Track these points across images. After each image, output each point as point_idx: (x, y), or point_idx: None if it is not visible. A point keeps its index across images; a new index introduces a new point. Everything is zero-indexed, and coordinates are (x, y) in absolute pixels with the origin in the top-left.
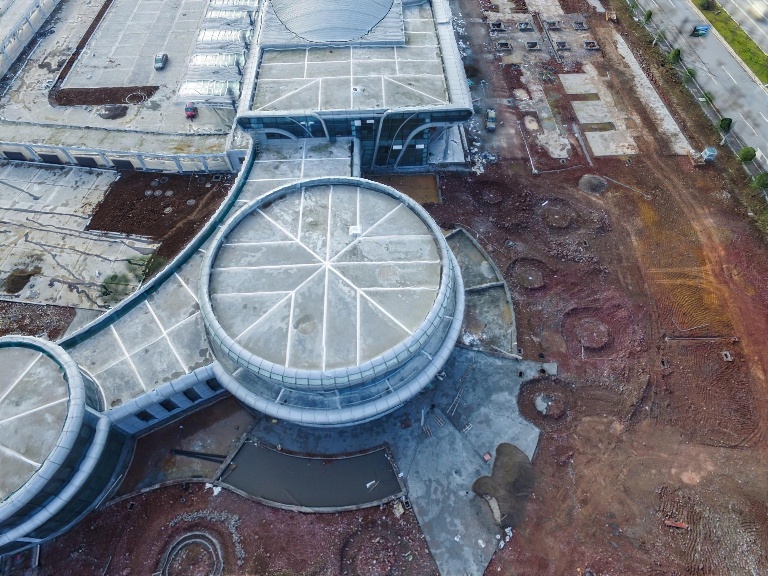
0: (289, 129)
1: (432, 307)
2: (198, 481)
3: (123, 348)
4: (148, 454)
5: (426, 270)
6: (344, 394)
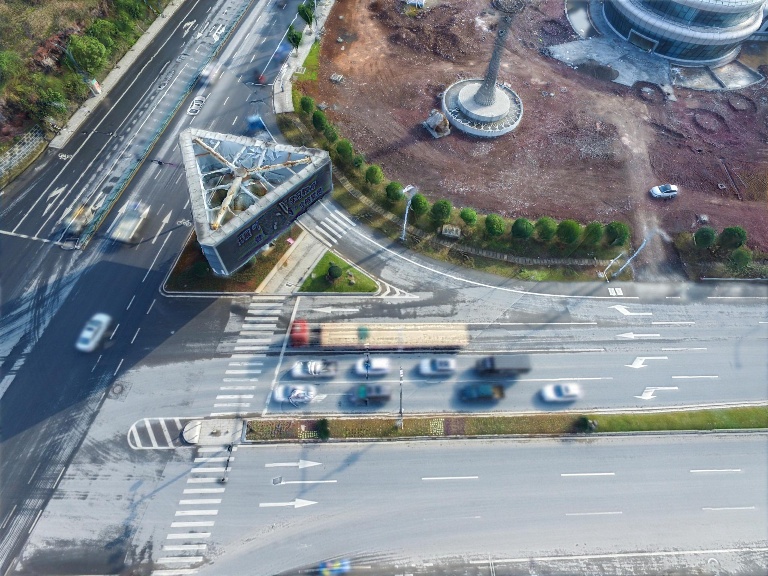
0: None
1: None
2: None
3: None
4: None
5: None
6: None
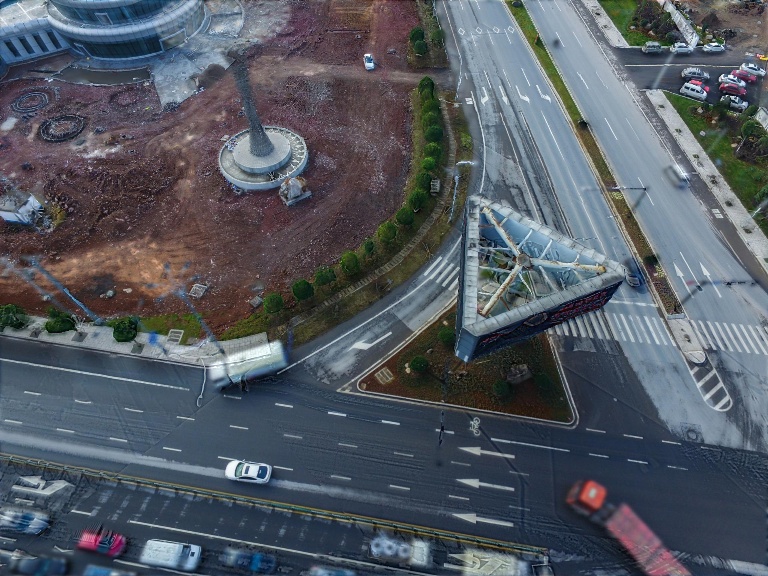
0: None
1: None
2: (40, 77)
3: (1, 18)
4: (15, 72)
5: None
6: (116, 25)
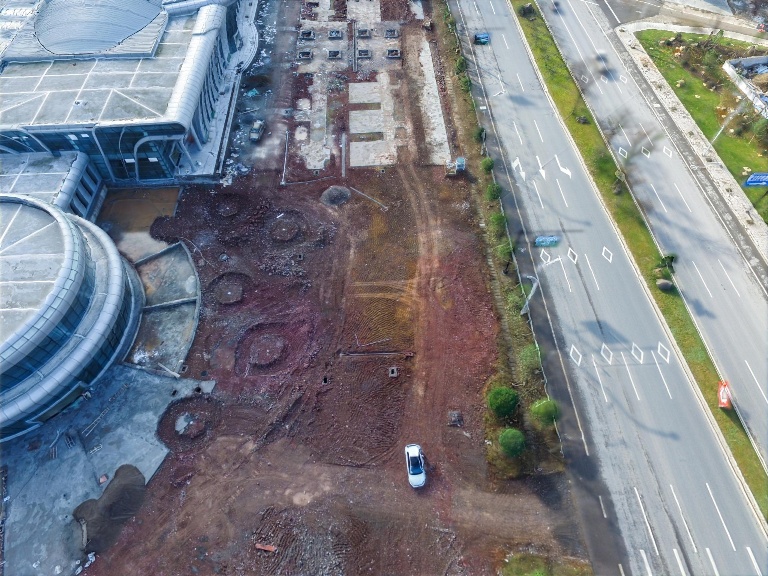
0: (5, 144)
1: (19, 329)
2: None
3: None
4: None
5: (44, 290)
6: None
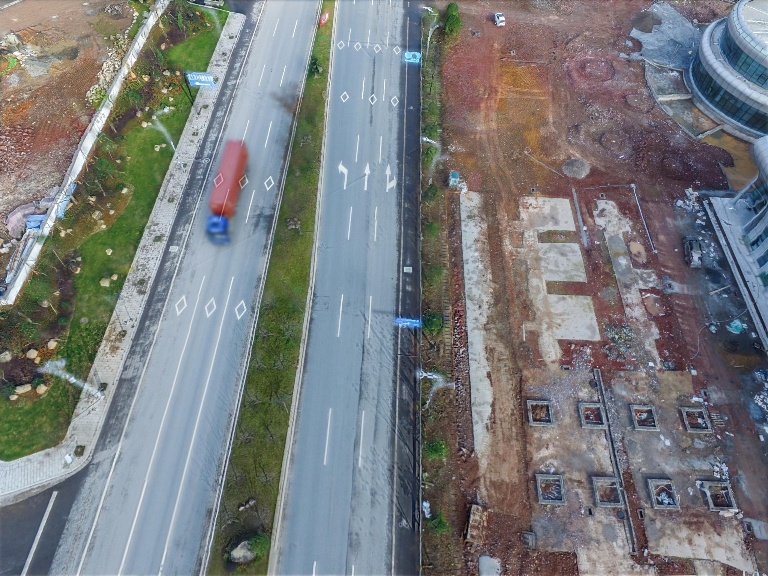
0: None
1: None
2: None
3: None
4: None
5: (751, 29)
6: None
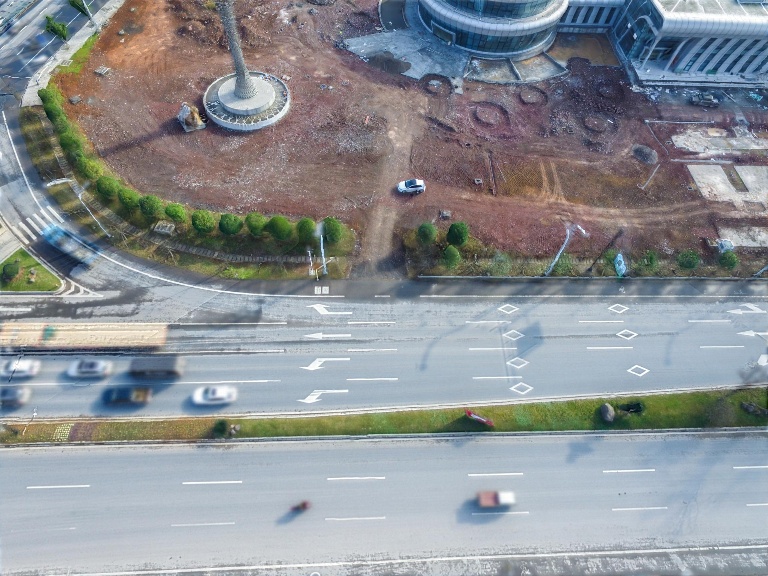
0: None
1: None
2: None
3: None
4: None
5: None
6: None
